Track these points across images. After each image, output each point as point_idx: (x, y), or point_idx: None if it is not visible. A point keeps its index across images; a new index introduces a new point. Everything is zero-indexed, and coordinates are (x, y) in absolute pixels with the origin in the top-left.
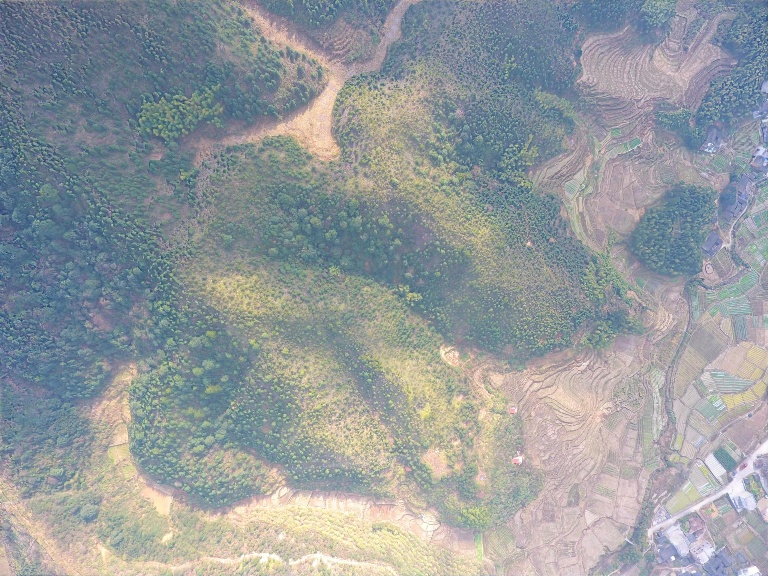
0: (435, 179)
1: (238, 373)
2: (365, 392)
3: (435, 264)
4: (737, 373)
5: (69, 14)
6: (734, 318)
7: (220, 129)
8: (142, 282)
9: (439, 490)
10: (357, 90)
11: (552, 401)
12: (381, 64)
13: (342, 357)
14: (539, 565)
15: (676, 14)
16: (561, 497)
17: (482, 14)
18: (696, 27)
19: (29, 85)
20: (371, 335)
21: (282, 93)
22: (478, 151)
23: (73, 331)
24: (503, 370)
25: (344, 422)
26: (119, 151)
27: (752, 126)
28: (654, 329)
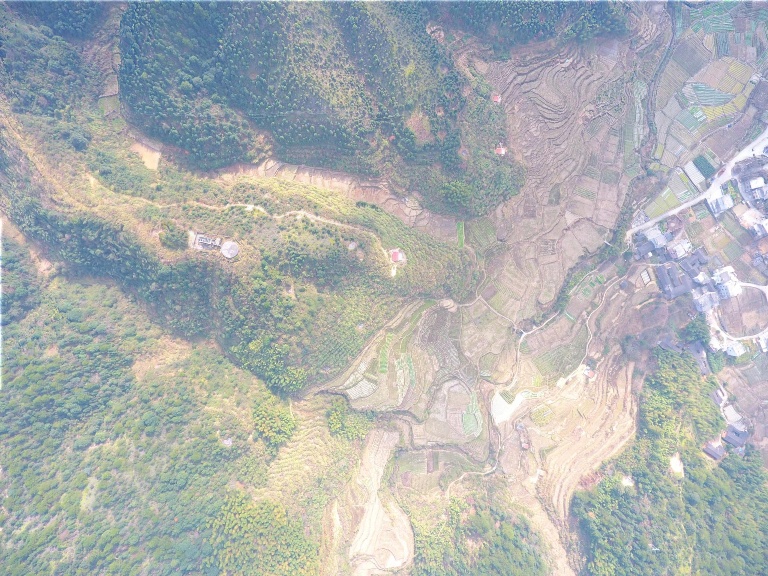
0: None
1: None
2: (351, 48)
3: None
4: (718, 87)
5: None
6: (717, 34)
7: None
8: None
9: (422, 160)
10: None
11: (535, 96)
12: None
13: (329, 1)
14: (519, 260)
15: None
16: (542, 196)
17: None
18: None
19: None
20: None
21: None
22: None
23: None
24: (488, 57)
25: (330, 73)
26: None
27: None
28: (637, 35)
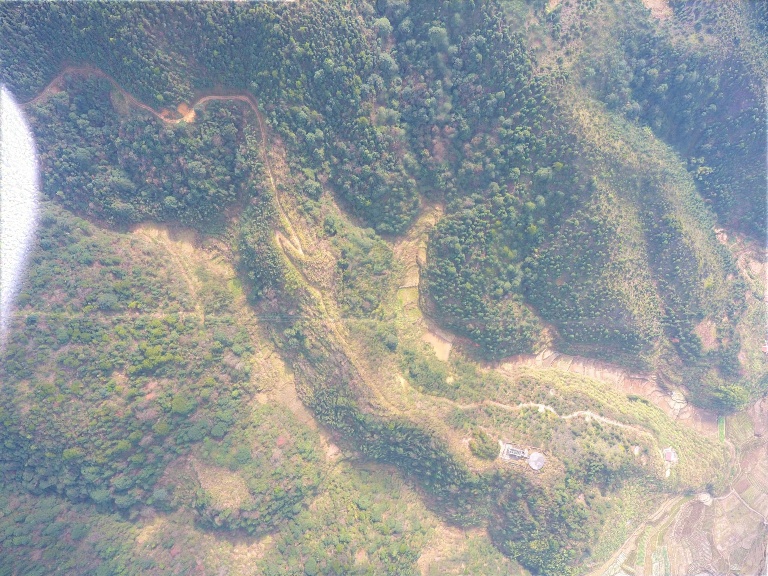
0: (762, 47)
1: (559, 215)
2: (652, 257)
3: (741, 134)
4: None
5: None
6: None
7: None
8: None
9: (703, 363)
10: None
11: None
12: None
13: (643, 216)
14: None
15: None
16: None
17: None
18: None
19: None
20: (678, 195)
21: None
22: None
23: (411, 157)
24: (764, 258)
25: (633, 282)
26: None
27: None
28: None
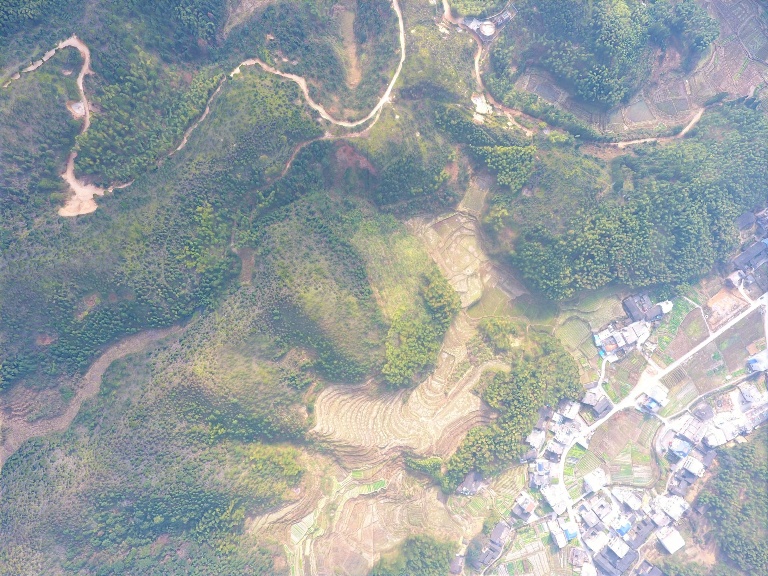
0: (92, 570)
1: None
2: None
3: None
4: None
5: None
6: None
7: None
8: None
9: None
10: (23, 465)
11: None
12: (70, 422)
13: None
14: None
15: (445, 351)
16: None
17: (175, 393)
18: (460, 372)
19: None
20: None
21: None
22: (165, 521)
23: None
24: None
25: None
26: None
27: (518, 469)
28: None
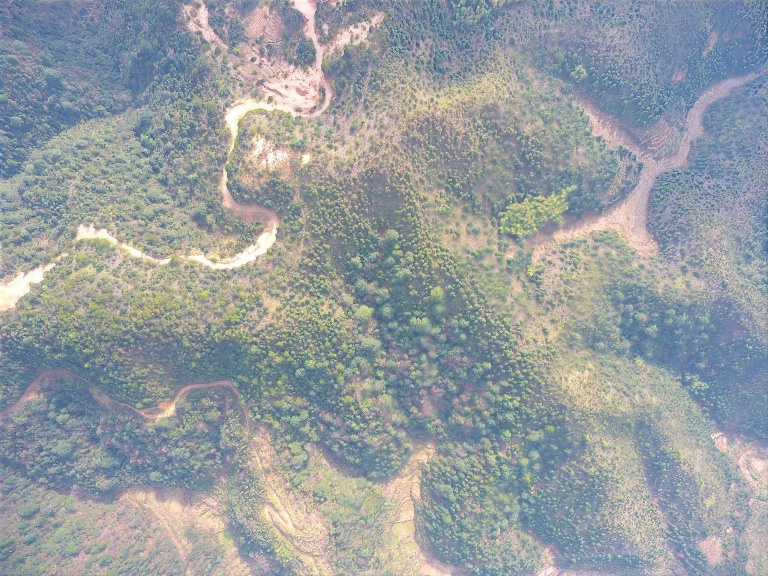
0: (751, 278)
1: None
2: (651, 479)
3: (735, 358)
4: None
5: (477, 125)
6: None
7: (555, 224)
8: (489, 376)
9: None
10: (677, 188)
11: None
12: (687, 159)
13: (640, 446)
14: None
15: None
16: None
17: None
18: None
19: (431, 191)
20: None
21: (612, 190)
22: None
23: (399, 416)
24: (765, 456)
25: (633, 509)
26: (490, 251)
27: None
28: None
